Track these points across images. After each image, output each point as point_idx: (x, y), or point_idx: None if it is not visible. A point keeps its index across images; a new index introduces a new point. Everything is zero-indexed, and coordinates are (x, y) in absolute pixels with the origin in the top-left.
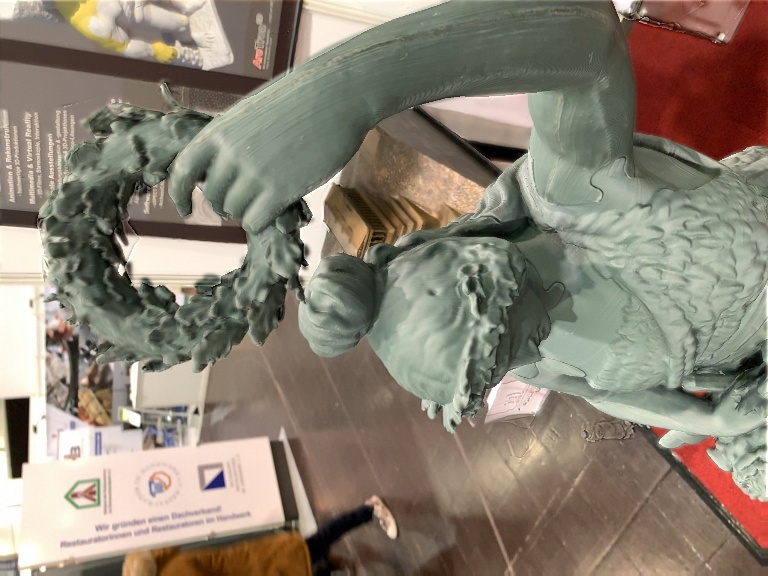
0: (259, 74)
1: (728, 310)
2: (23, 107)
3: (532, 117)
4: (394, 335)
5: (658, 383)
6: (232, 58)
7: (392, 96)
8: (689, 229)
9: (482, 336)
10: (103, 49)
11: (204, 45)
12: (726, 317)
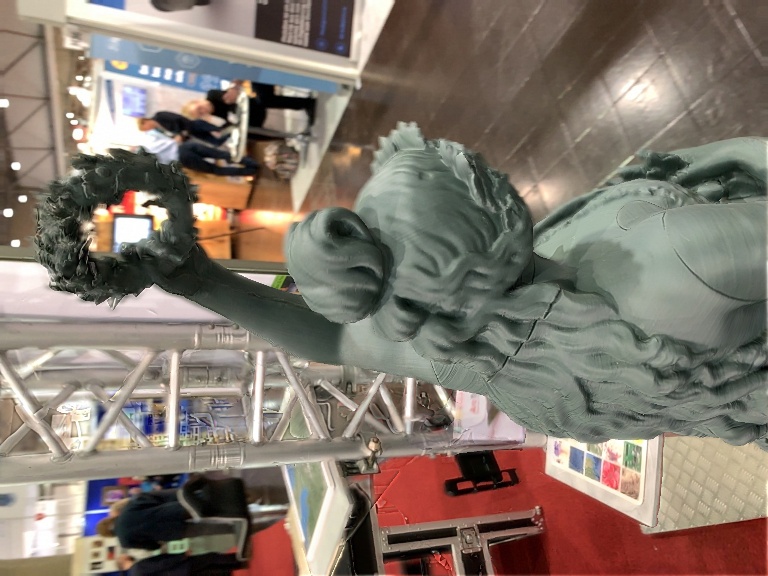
0: None
1: None
2: None
3: (380, 344)
4: None
5: None
6: None
7: None
8: None
9: None
10: None
11: None
12: None
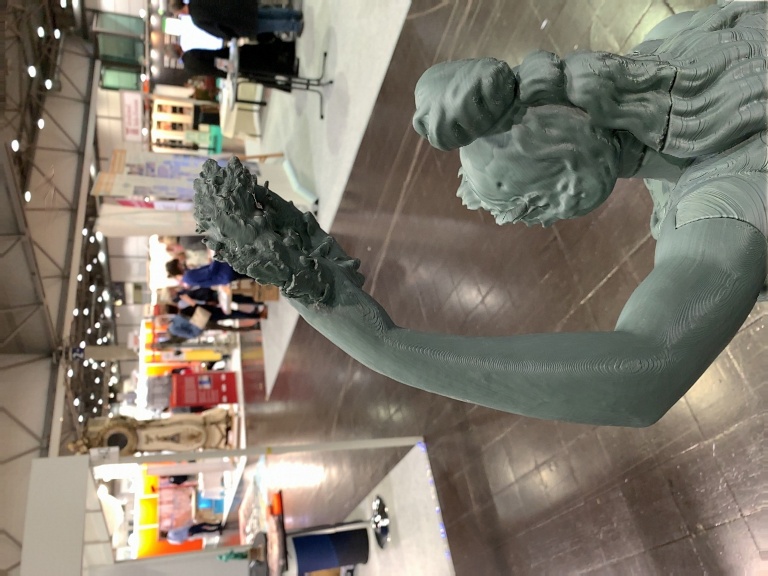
0: None
1: None
2: None
3: None
4: (465, 155)
5: None
6: None
7: None
8: None
9: None
10: None
11: None
12: None
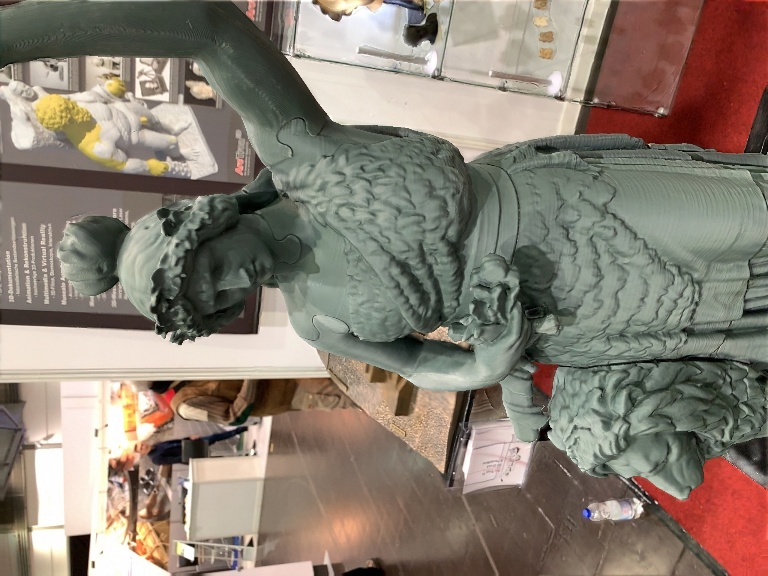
0: (242, 180)
1: (426, 243)
2: (39, 220)
3: None
4: (121, 264)
5: (402, 324)
6: (217, 168)
7: (1, 40)
8: (367, 172)
9: (171, 251)
10: (105, 168)
11: (191, 159)
12: (434, 253)
